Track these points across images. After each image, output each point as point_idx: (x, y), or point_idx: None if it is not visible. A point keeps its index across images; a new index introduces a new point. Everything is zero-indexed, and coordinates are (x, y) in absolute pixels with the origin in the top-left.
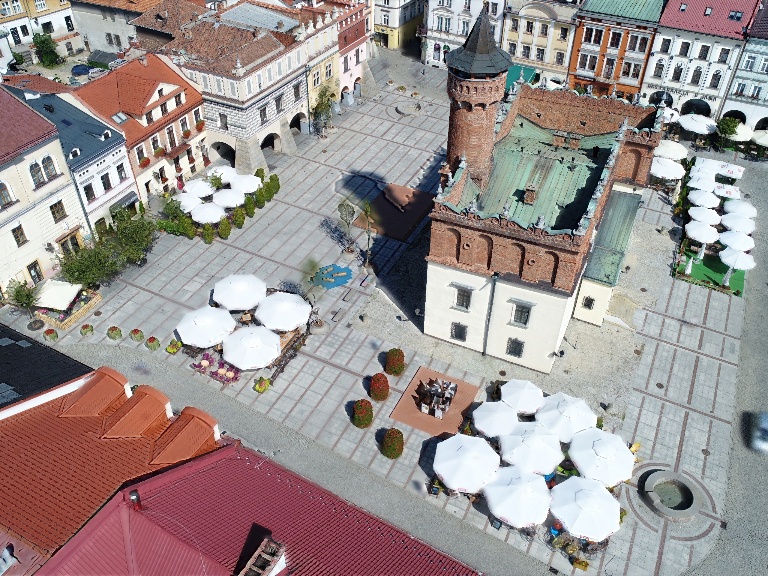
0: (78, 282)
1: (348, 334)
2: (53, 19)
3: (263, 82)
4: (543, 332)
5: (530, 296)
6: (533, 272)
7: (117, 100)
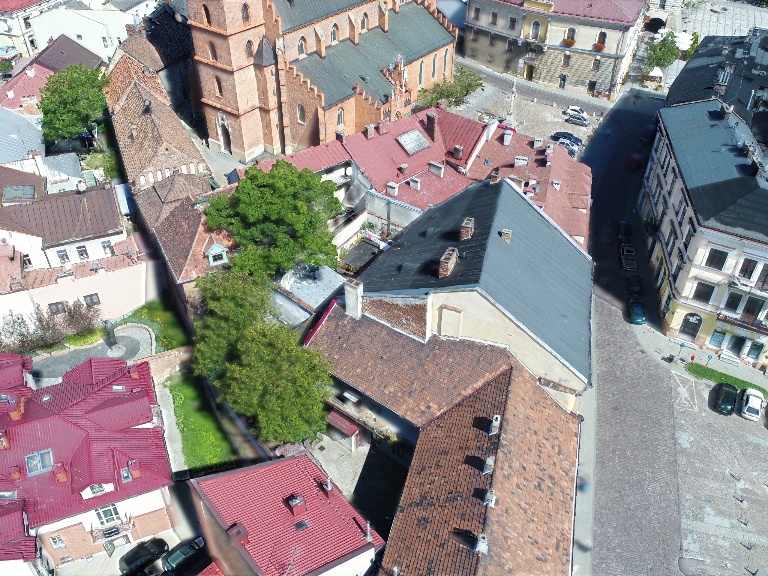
0: (659, 67)
1: None
2: None
3: None
4: None
5: None
6: None
7: None
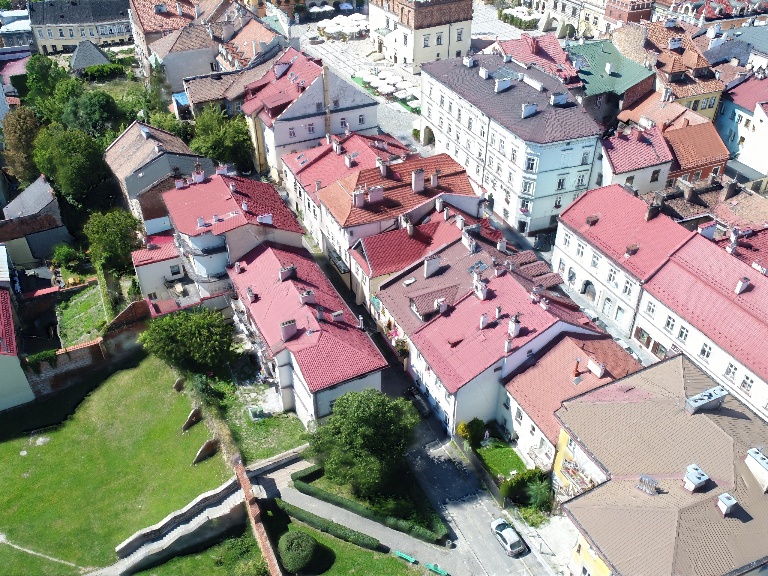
0: None
1: None
2: None
3: None
4: None
5: None
6: None
7: None
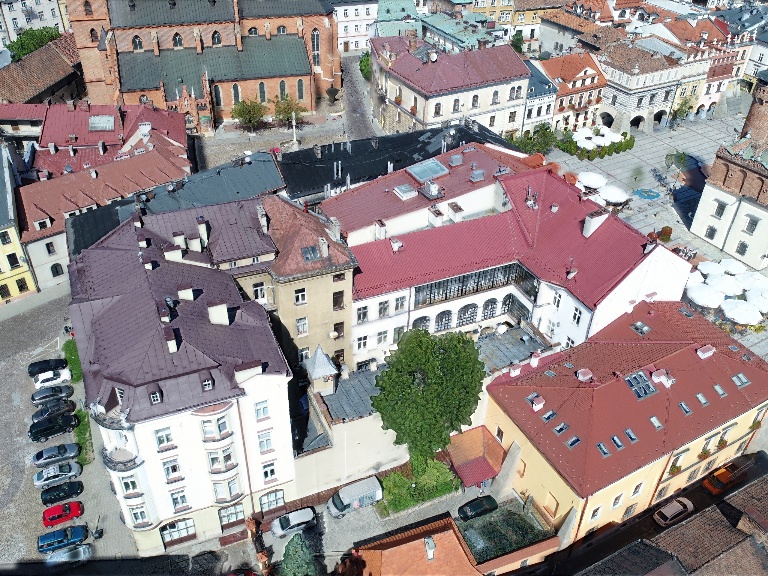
0: None
1: (644, 219)
2: (524, 29)
3: (647, 82)
4: (762, 239)
5: (760, 213)
6: (765, 198)
7: (560, 71)
